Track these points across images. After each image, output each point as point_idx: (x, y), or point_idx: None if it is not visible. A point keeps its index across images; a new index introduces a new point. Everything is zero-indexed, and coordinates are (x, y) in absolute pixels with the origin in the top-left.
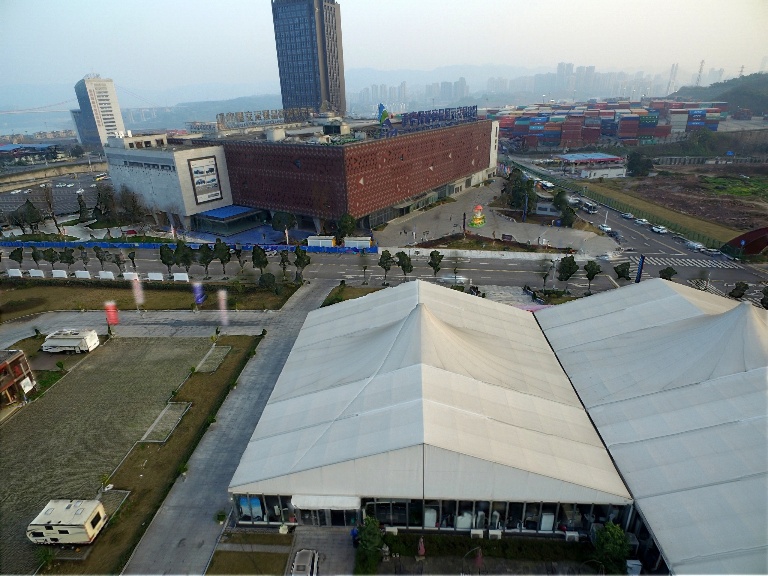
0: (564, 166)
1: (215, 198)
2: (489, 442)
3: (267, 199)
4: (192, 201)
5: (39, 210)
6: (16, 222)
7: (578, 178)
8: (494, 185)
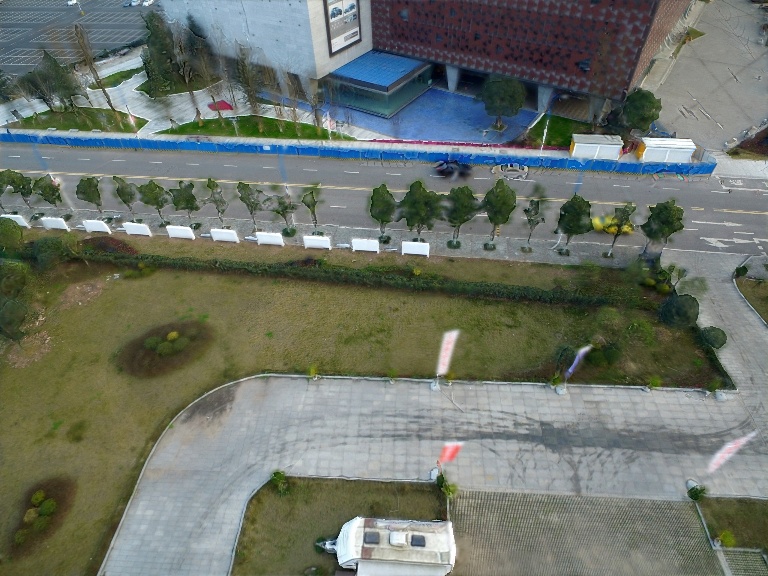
0: None
1: (352, 41)
2: None
3: (448, 45)
4: (324, 51)
5: (75, 76)
6: (37, 94)
7: None
8: None
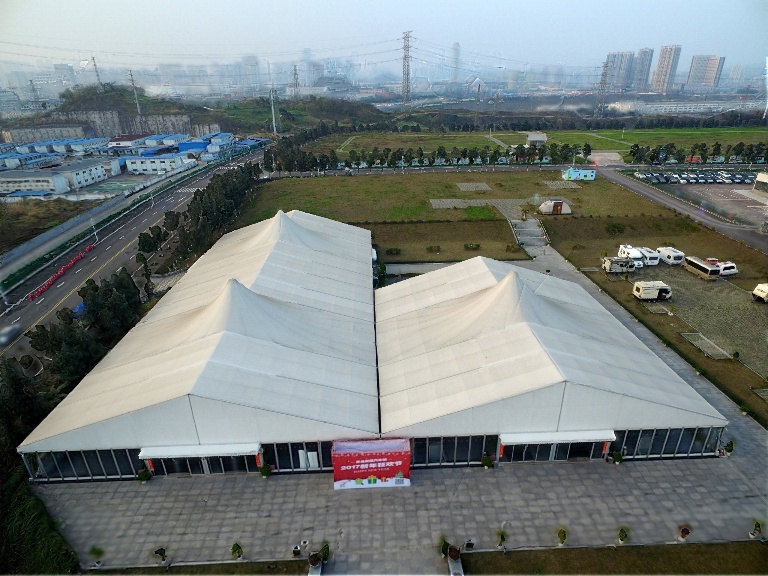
0: None
1: None
2: None
3: None
4: None
5: None
6: None
7: None
8: None
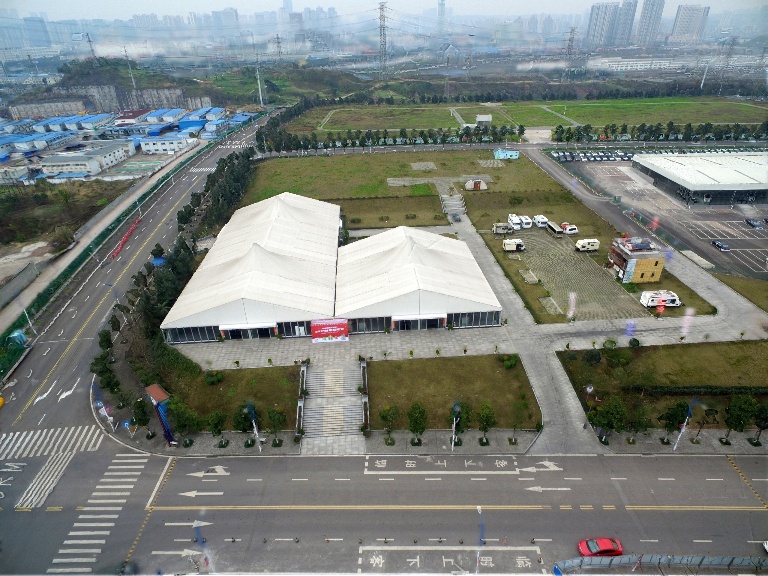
0: None
1: None
2: (382, 236)
3: None
4: None
5: None
6: None
7: None
8: None
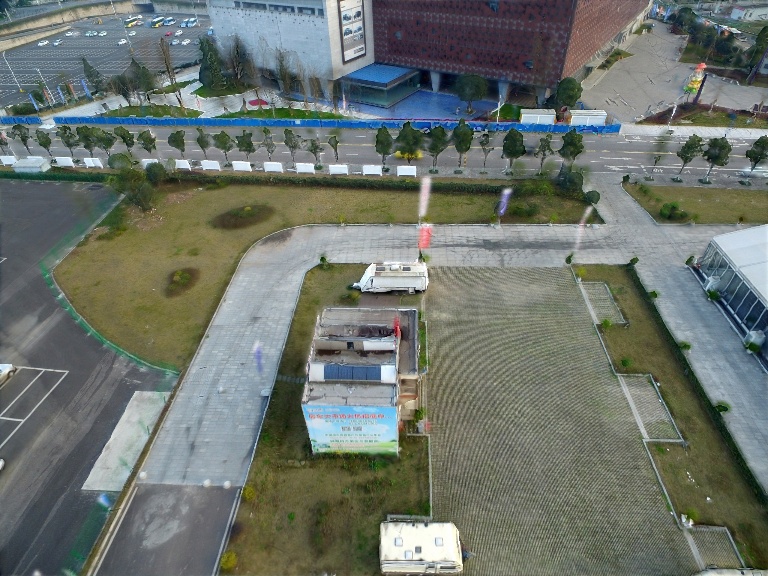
0: (701, 3)
1: (359, 54)
2: None
3: (431, 56)
4: (339, 59)
5: (157, 74)
6: (124, 90)
7: (746, 20)
8: (658, 31)
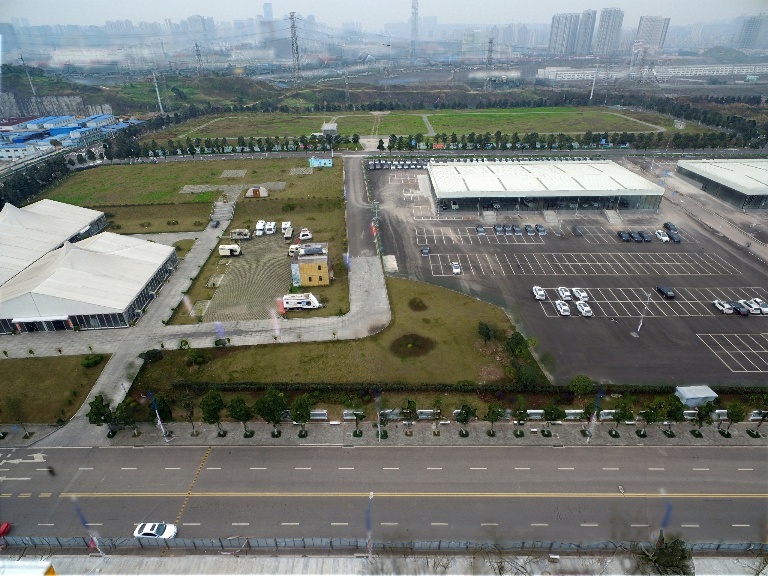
0: None
1: None
2: None
3: None
4: None
5: None
6: None
7: None
8: None
